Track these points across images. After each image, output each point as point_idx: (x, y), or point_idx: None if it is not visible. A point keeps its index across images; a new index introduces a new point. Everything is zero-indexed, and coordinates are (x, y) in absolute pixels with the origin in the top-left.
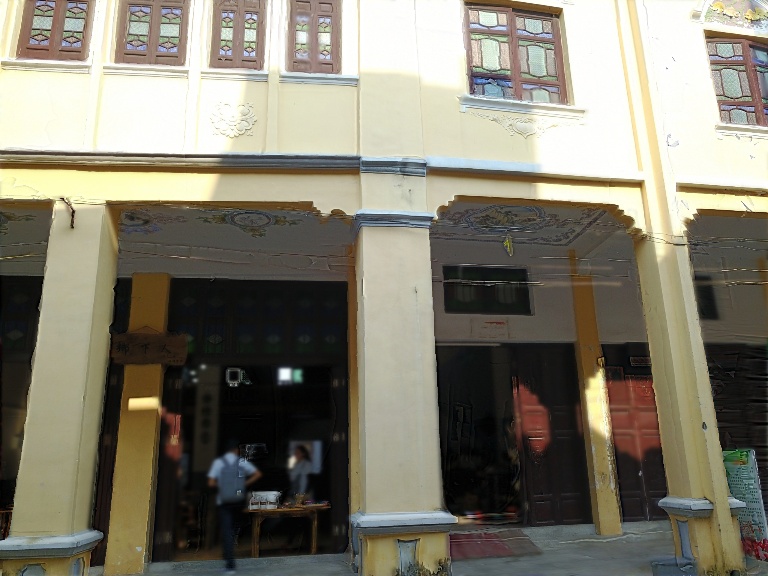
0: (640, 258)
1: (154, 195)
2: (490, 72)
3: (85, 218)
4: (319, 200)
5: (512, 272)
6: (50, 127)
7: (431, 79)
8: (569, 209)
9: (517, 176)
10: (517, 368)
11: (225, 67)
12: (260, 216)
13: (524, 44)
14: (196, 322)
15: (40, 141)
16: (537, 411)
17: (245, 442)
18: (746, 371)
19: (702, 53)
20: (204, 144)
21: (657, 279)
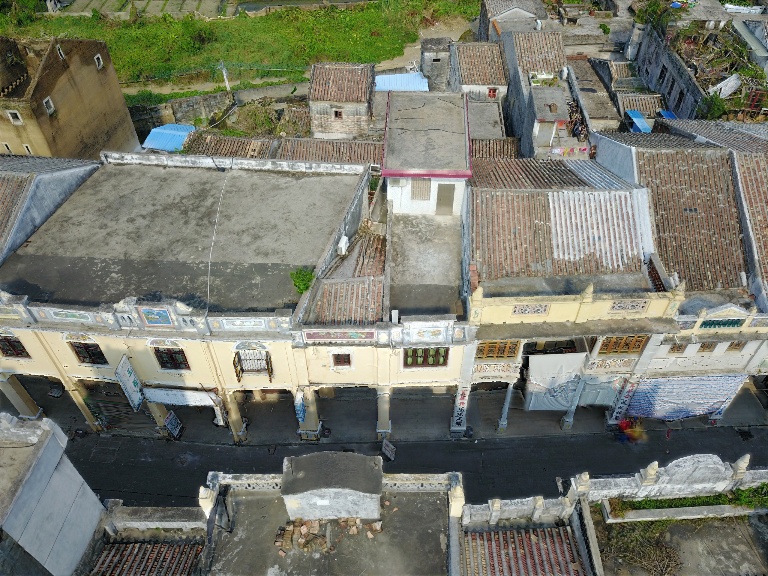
0: None
1: None
2: (7, 349)
3: None
4: None
5: None
6: None
7: None
8: None
9: None
10: None
11: None
12: None
13: None
14: None
15: None
16: None
17: None
18: None
19: (68, 347)
20: None
21: None
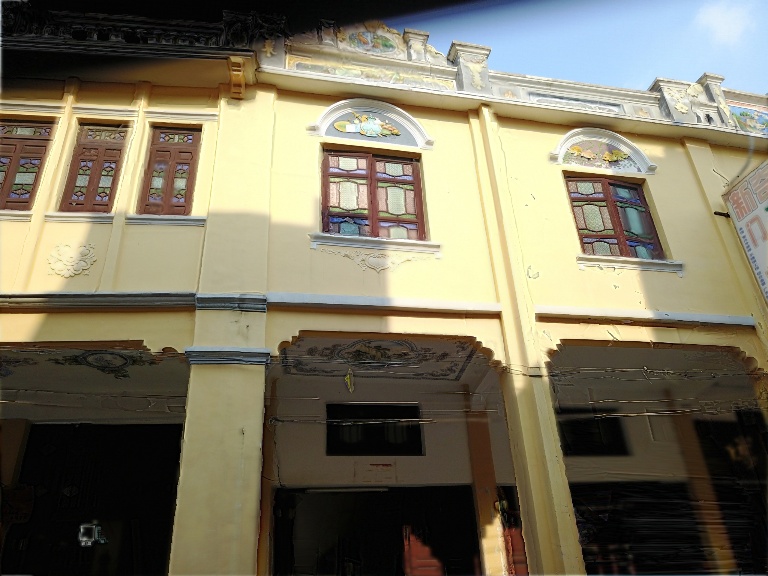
0: (505, 391)
1: None
2: (347, 211)
3: None
4: (150, 338)
5: (402, 409)
6: None
7: (283, 218)
8: (439, 342)
9: (367, 310)
10: (408, 515)
11: (74, 211)
12: (114, 356)
13: (384, 185)
14: (52, 472)
15: None
16: (430, 565)
17: None
18: (621, 513)
19: (561, 191)
20: (37, 284)
21: (516, 413)
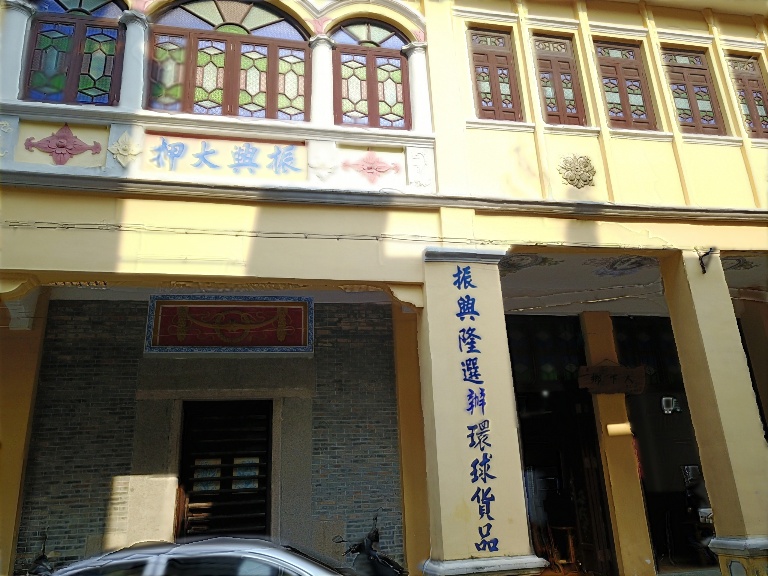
0: None
1: (748, 245)
2: None
3: (711, 265)
4: None
5: None
6: (657, 187)
7: None
8: None
9: None
10: None
11: (756, 137)
12: (734, 262)
13: None
14: (632, 355)
15: (654, 199)
16: None
17: (683, 464)
18: None
19: None
20: (767, 202)
21: None
